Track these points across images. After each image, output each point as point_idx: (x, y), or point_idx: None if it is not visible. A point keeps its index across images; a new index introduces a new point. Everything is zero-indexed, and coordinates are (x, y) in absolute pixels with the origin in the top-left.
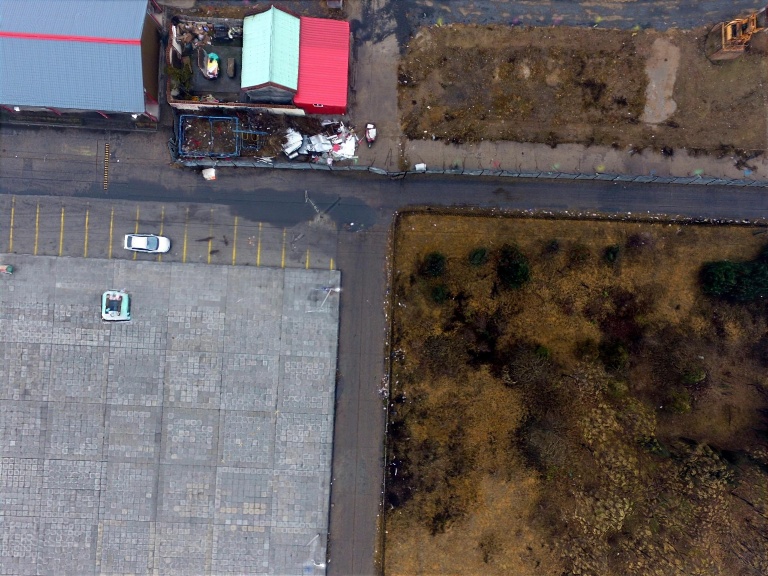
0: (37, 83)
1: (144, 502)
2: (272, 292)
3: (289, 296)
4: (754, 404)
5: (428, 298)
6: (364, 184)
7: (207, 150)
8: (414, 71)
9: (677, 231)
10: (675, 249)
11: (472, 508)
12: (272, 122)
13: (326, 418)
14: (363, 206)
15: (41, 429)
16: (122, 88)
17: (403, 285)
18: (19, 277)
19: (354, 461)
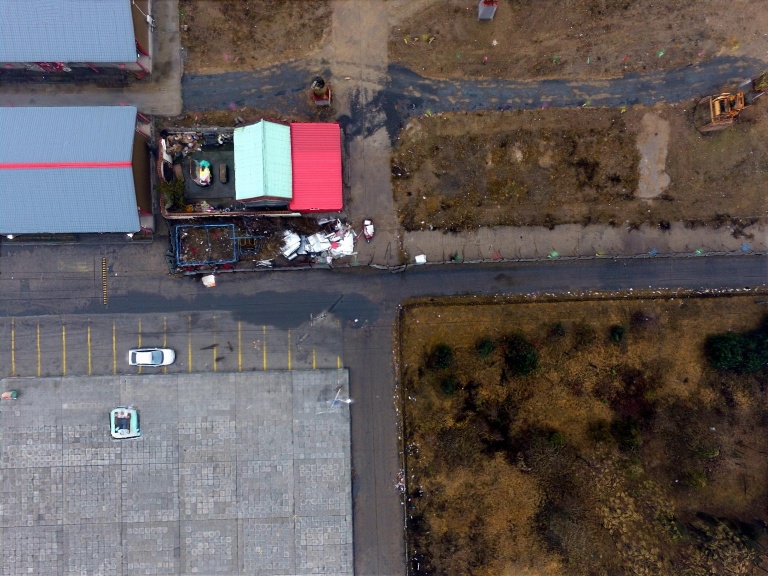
0: (29, 211)
1: None
2: (281, 396)
3: (298, 399)
4: (767, 471)
5: (438, 390)
6: (365, 279)
7: (205, 257)
8: (407, 162)
9: (680, 304)
10: (679, 322)
11: None
12: (269, 227)
13: (344, 519)
14: (366, 301)
15: (58, 553)
16: (116, 210)
17: (412, 378)
18: (24, 401)
19: (375, 559)
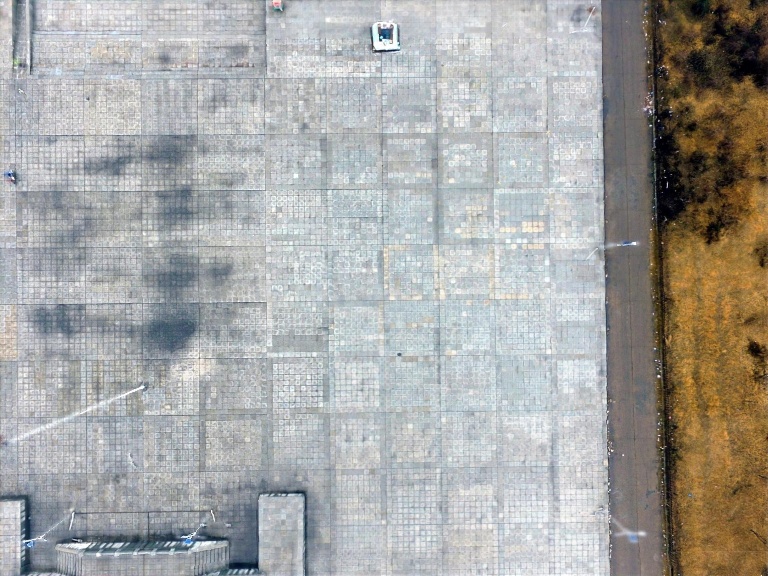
0: None
1: (426, 226)
2: (536, 15)
3: (552, 18)
4: None
5: (688, 13)
6: None
7: None
8: None
9: None
10: None
11: (745, 214)
12: None
13: (596, 135)
14: None
15: (322, 161)
16: None
17: (662, 2)
18: (290, 14)
19: (624, 178)
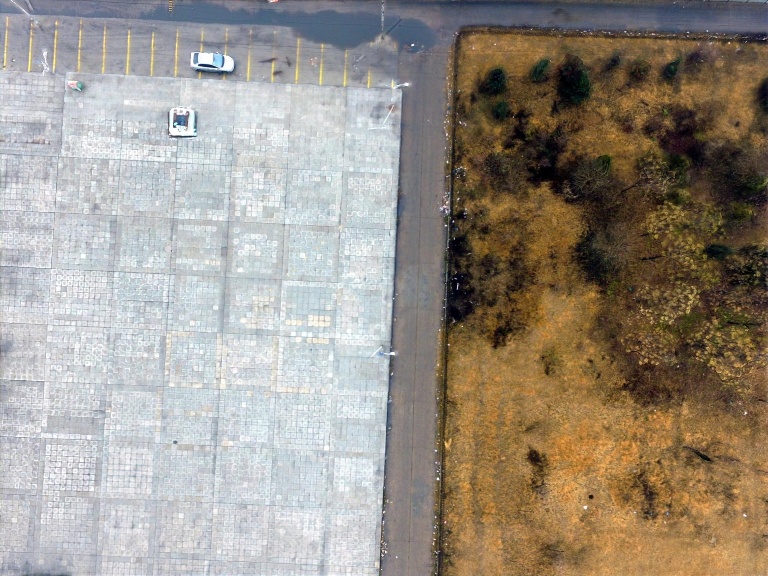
0: None
1: (211, 314)
2: (335, 110)
3: (352, 113)
4: None
5: (488, 116)
6: (424, 6)
7: None
8: None
9: (736, 49)
10: (734, 67)
11: (533, 321)
12: None
13: (389, 233)
14: (423, 28)
15: (111, 242)
16: None
17: (464, 104)
18: (88, 94)
19: (416, 277)
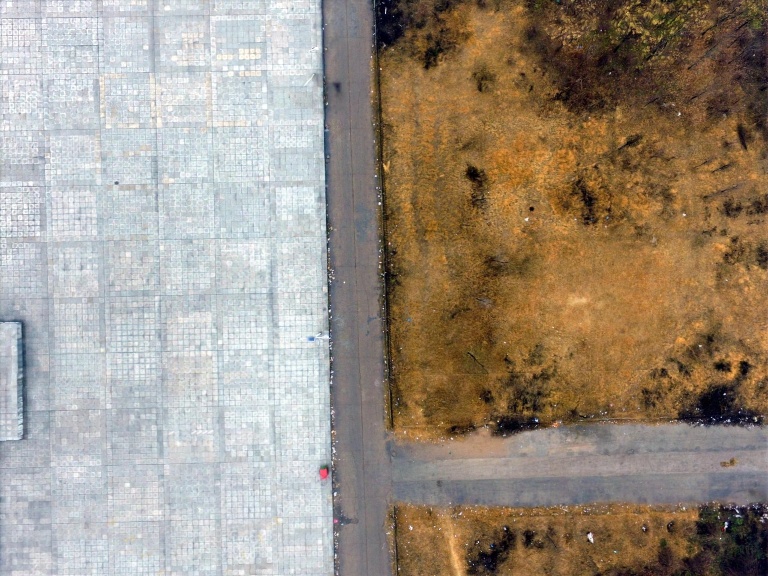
0: None
1: (142, 54)
2: None
3: None
4: None
5: None
6: None
7: None
8: None
9: None
10: None
11: (463, 39)
12: None
13: None
14: None
15: None
16: None
17: None
18: None
19: (344, 6)
